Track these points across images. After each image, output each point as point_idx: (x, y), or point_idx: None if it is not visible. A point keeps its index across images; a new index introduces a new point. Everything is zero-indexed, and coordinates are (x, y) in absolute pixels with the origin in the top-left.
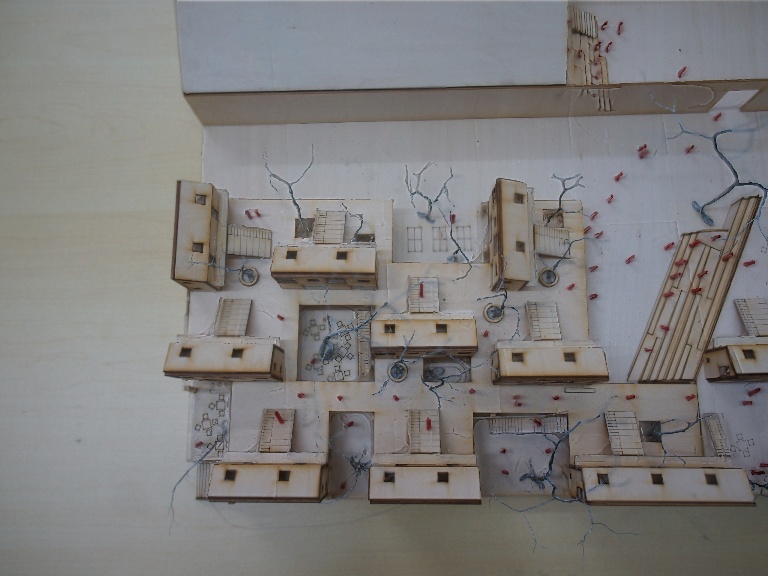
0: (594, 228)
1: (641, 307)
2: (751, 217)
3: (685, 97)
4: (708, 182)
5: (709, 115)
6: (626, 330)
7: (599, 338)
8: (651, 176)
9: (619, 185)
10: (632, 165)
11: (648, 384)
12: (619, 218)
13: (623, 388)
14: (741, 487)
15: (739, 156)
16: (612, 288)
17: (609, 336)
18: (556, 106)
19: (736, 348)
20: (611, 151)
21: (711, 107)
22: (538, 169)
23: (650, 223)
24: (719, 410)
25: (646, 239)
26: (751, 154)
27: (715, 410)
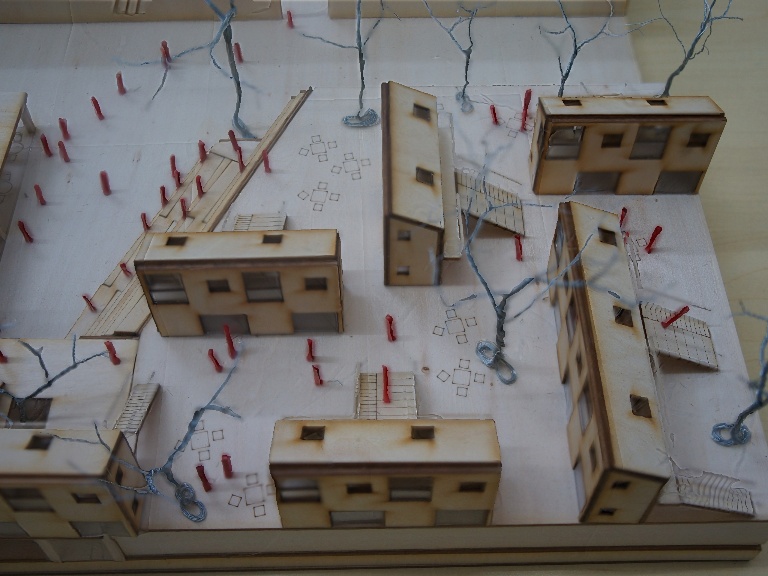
0: (67, 150)
1: (111, 254)
2: (292, 112)
3: (251, 2)
4: (264, 96)
5: (283, 22)
6: (75, 286)
7: (24, 298)
8: (177, 88)
9: (124, 99)
10: (151, 76)
11: (49, 339)
12: (111, 138)
13: (0, 345)
14: (91, 453)
15: (319, 67)
16: (70, 228)
17: (42, 295)
18: (46, 2)
19: (159, 235)
20: (124, 60)
21: (280, 7)
22: (4, 80)
23: (159, 144)
24: (170, 381)
25: (147, 164)
26: (337, 64)
27: (162, 381)
